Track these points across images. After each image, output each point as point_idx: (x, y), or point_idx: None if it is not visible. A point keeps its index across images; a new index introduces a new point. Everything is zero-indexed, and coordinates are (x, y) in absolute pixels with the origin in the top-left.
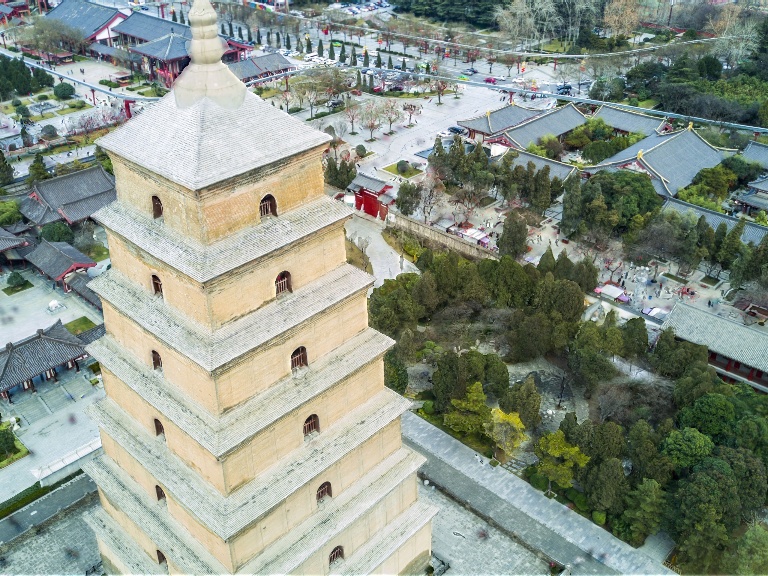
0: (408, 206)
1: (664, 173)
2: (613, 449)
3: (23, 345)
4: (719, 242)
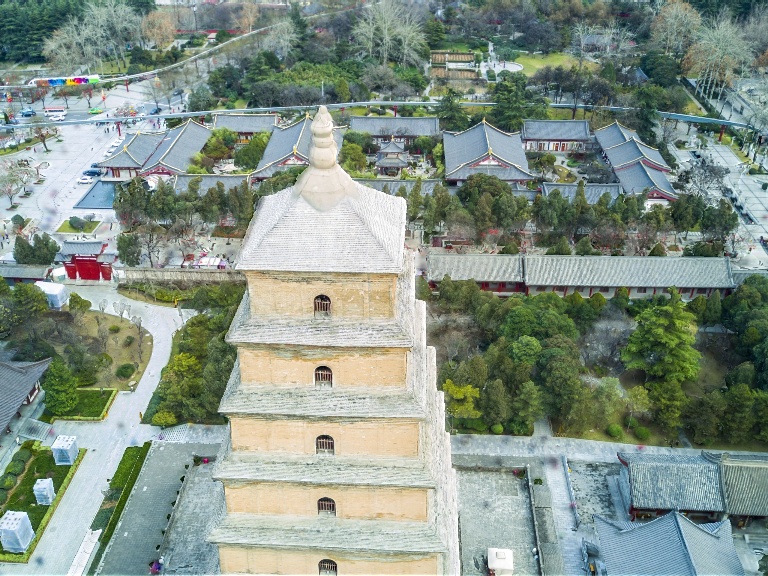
0: (131, 258)
1: None
2: (485, 375)
3: None
4: None
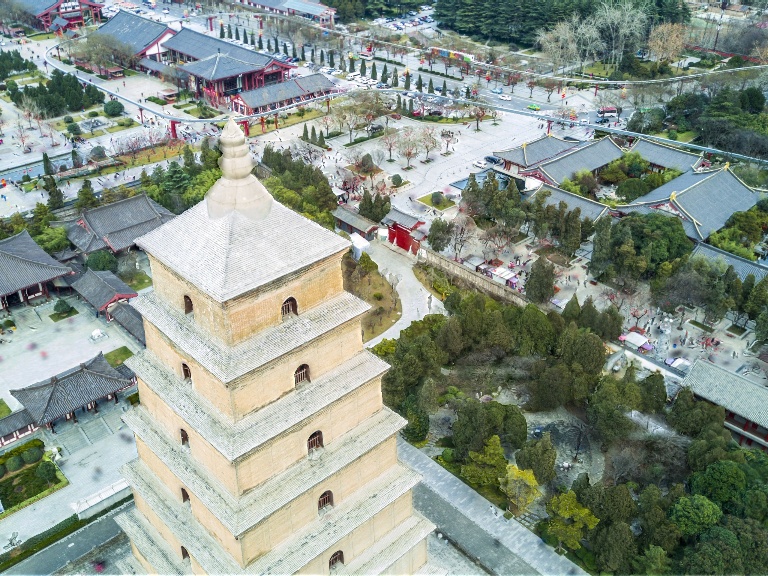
0: (439, 242)
1: (697, 215)
2: (623, 512)
3: (66, 378)
4: (746, 293)
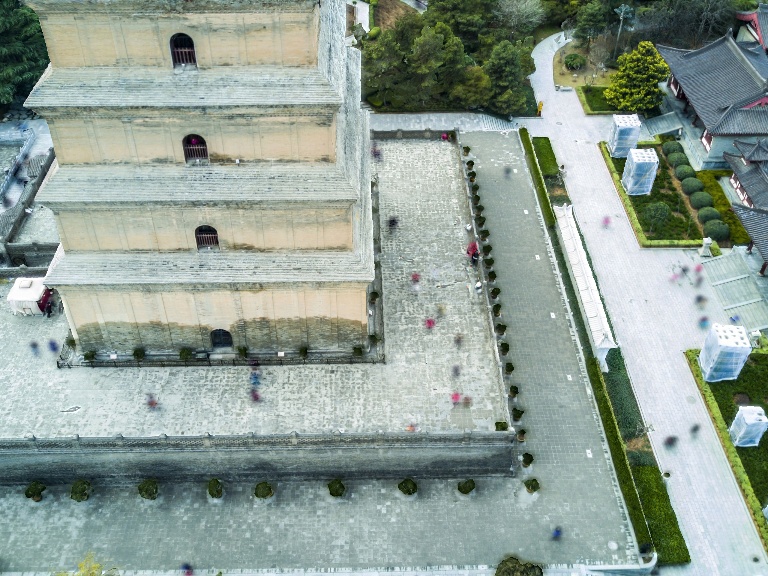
0: None
1: None
2: None
3: None
4: None
